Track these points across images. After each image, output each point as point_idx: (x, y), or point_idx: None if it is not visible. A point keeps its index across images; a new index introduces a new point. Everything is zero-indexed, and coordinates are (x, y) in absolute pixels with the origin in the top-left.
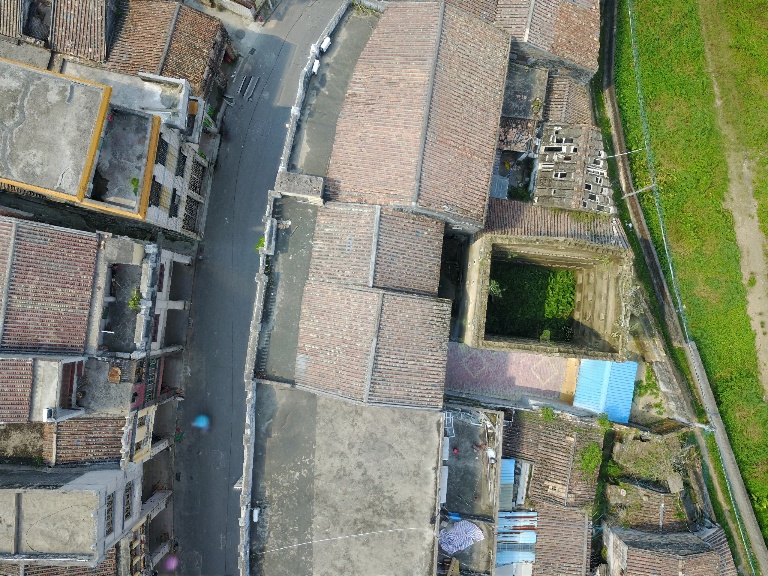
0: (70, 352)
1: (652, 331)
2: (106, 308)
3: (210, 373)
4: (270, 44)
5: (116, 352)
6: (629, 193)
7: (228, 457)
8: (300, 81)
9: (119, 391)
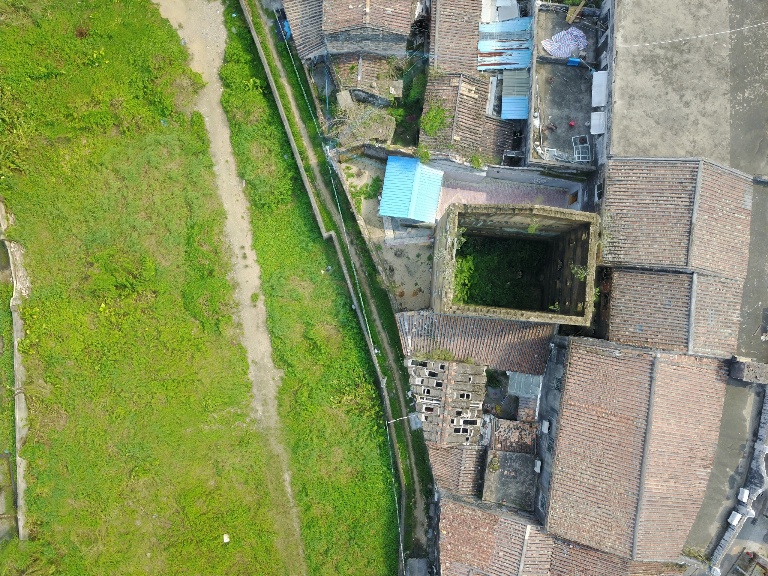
0: None
1: None
2: None
3: None
4: None
5: None
6: None
7: None
8: (767, 479)
9: None
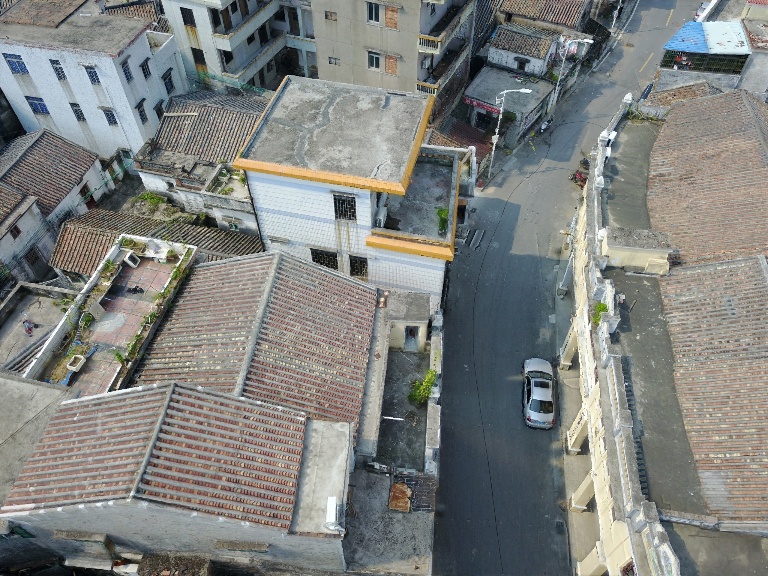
0: None
1: None
2: None
3: None
4: (492, 204)
5: None
6: None
7: None
8: (602, 155)
9: (409, 527)
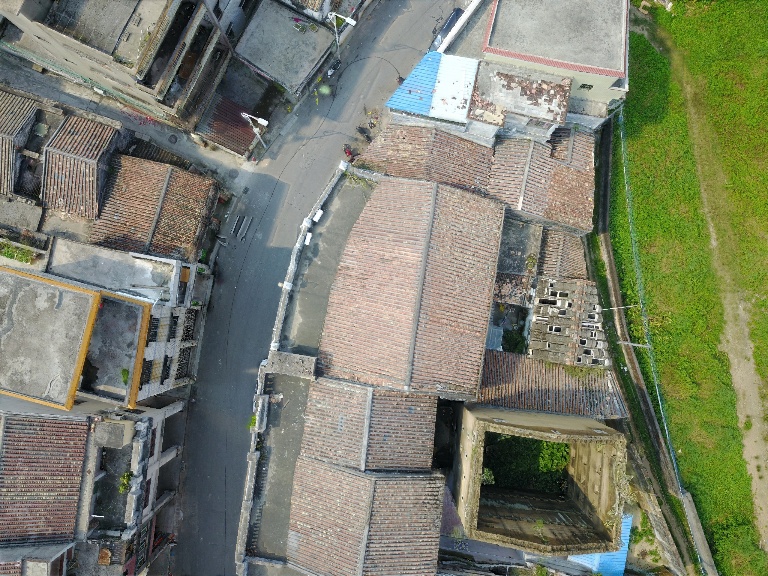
0: (59, 540)
1: (647, 487)
2: (97, 483)
3: (203, 518)
4: (264, 183)
5: (106, 530)
6: (624, 341)
7: None
8: (292, 258)
9: (109, 573)
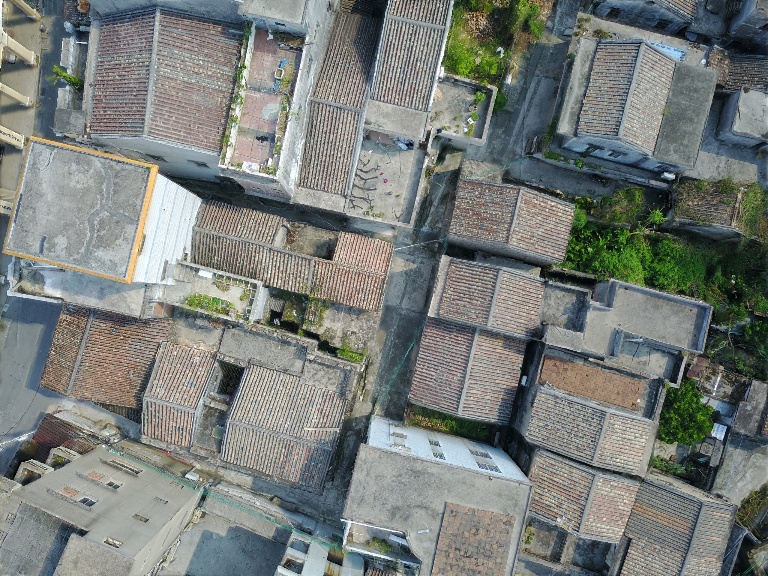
0: (110, 19)
1: None
2: None
3: None
4: None
5: None
6: None
7: None
8: None
9: None
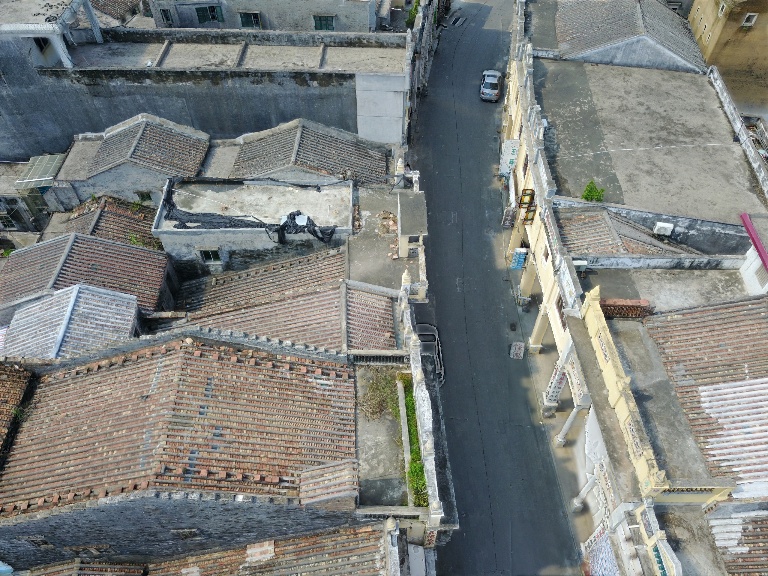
0: None
1: None
2: None
3: (437, 160)
4: (473, 6)
5: None
6: None
7: (460, 216)
8: None
9: None
